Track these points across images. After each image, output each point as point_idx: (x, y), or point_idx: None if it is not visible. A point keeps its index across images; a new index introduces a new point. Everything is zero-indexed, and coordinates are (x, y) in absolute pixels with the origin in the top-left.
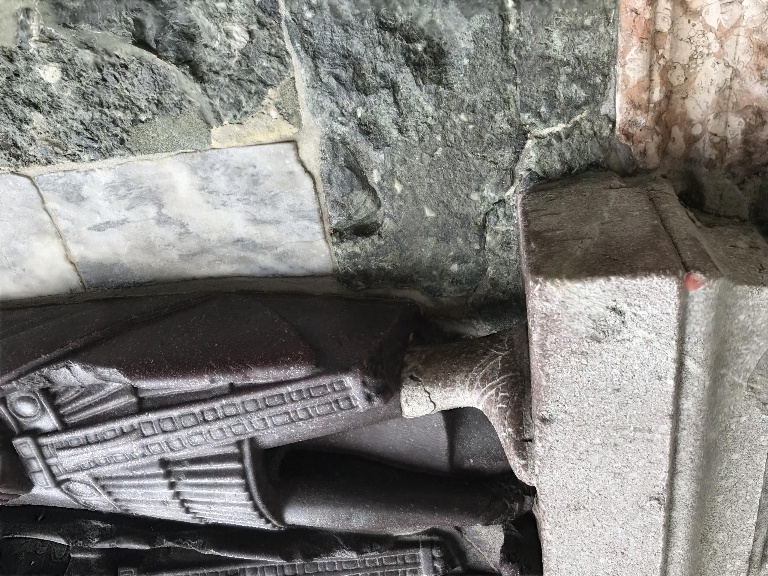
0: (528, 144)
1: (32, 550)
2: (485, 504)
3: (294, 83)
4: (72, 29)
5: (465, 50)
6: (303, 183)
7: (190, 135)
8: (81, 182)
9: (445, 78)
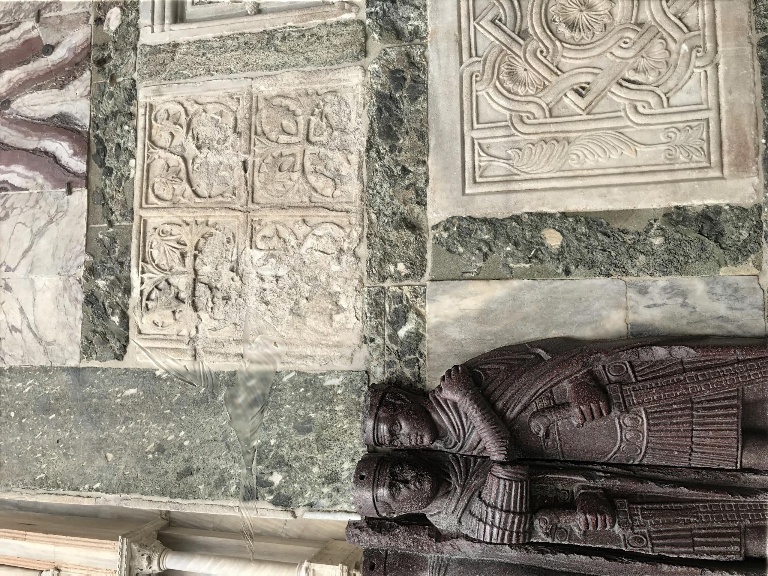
0: None
1: (545, 495)
2: None
3: (762, 254)
4: (674, 226)
5: None
6: (759, 293)
7: (710, 269)
8: (650, 285)
9: None
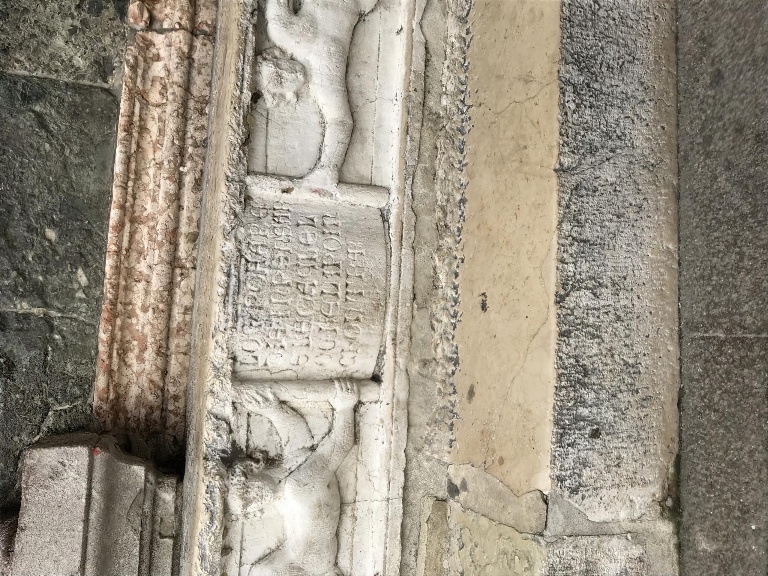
0: (49, 414)
1: None
2: None
3: None
4: None
5: (25, 365)
6: None
7: None
8: None
9: (12, 376)
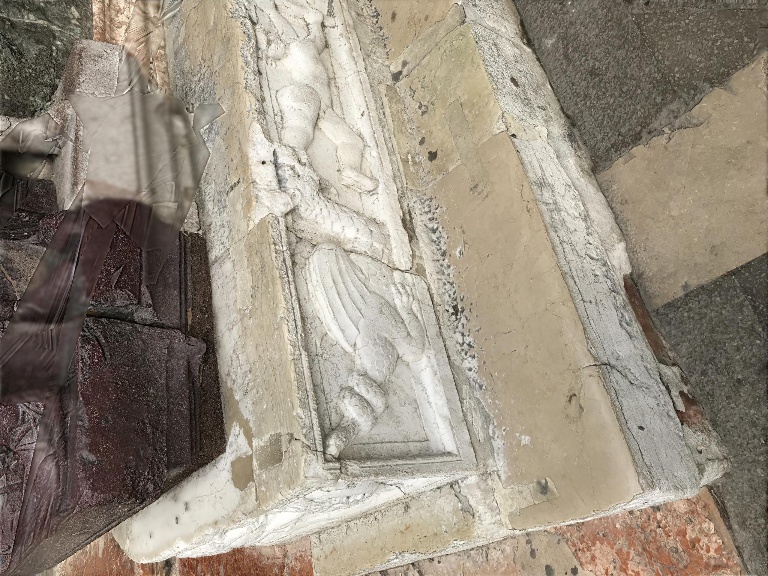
0: None
1: None
2: (27, 210)
3: None
4: None
5: (34, 53)
6: None
7: None
8: None
9: (24, 58)
